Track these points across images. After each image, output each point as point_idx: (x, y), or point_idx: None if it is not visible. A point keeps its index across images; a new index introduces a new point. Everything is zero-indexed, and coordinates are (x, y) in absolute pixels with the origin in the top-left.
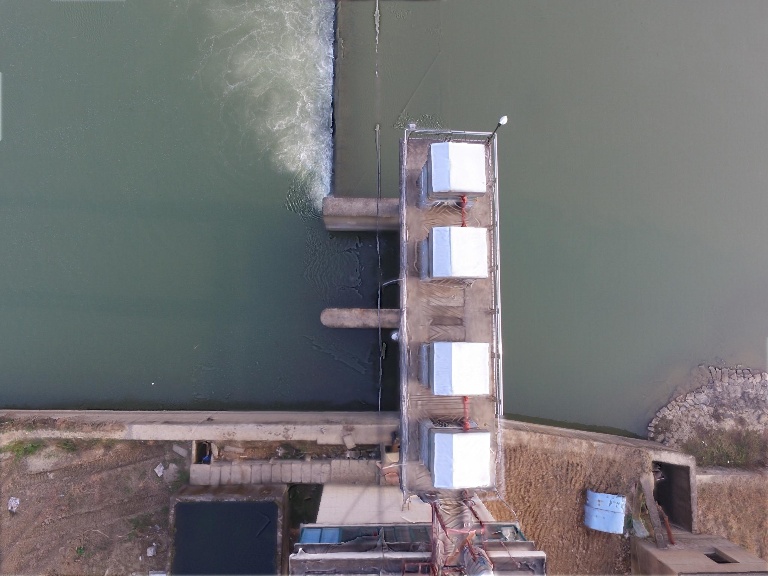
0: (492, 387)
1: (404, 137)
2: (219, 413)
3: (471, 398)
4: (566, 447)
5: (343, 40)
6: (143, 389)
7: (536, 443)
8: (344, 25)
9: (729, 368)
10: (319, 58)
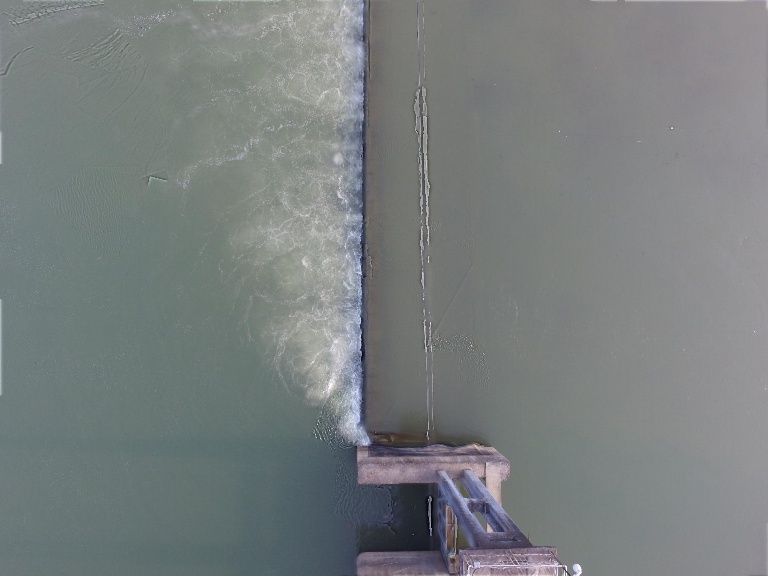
0: None
1: (468, 574)
2: None
3: None
4: None
5: (372, 258)
6: None
7: None
8: (372, 241)
9: None
10: (347, 275)
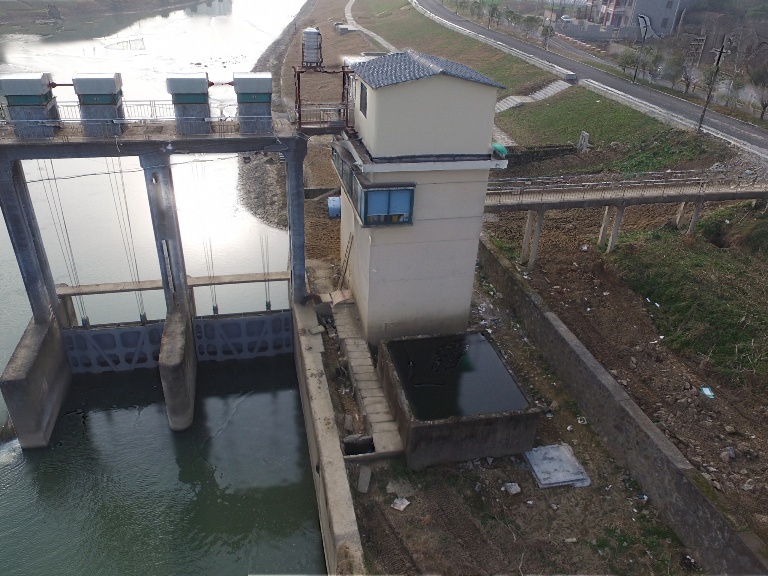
0: None
1: None
2: None
3: (223, 123)
4: None
5: None
6: None
7: None
8: None
9: None
10: None
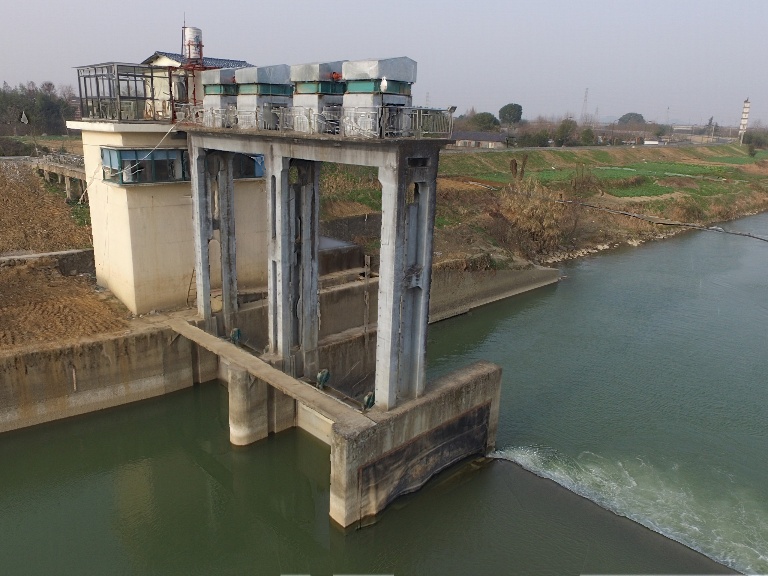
0: (219, 129)
1: None
2: None
3: None
4: (23, 348)
5: None
6: None
7: (68, 341)
8: None
9: None
10: None
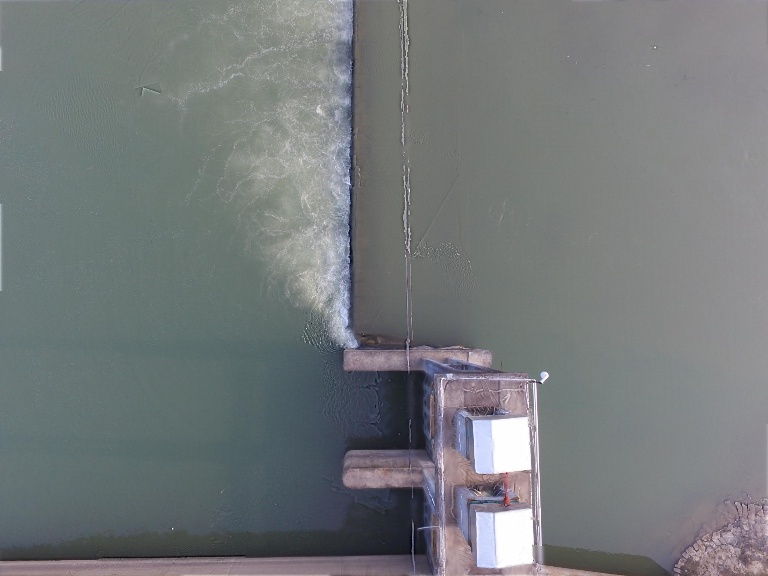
0: None
1: (441, 386)
2: (238, 563)
3: None
4: None
5: (360, 168)
6: (159, 532)
7: None
8: (361, 152)
9: (755, 503)
10: (336, 185)
